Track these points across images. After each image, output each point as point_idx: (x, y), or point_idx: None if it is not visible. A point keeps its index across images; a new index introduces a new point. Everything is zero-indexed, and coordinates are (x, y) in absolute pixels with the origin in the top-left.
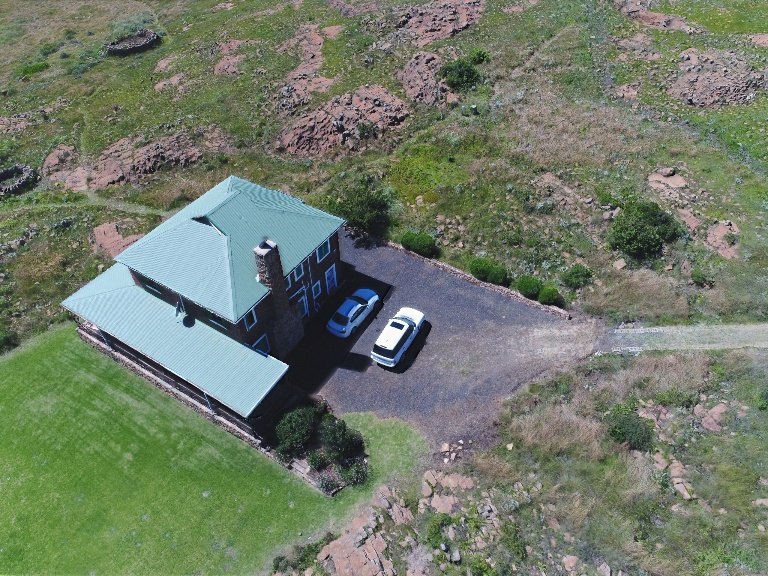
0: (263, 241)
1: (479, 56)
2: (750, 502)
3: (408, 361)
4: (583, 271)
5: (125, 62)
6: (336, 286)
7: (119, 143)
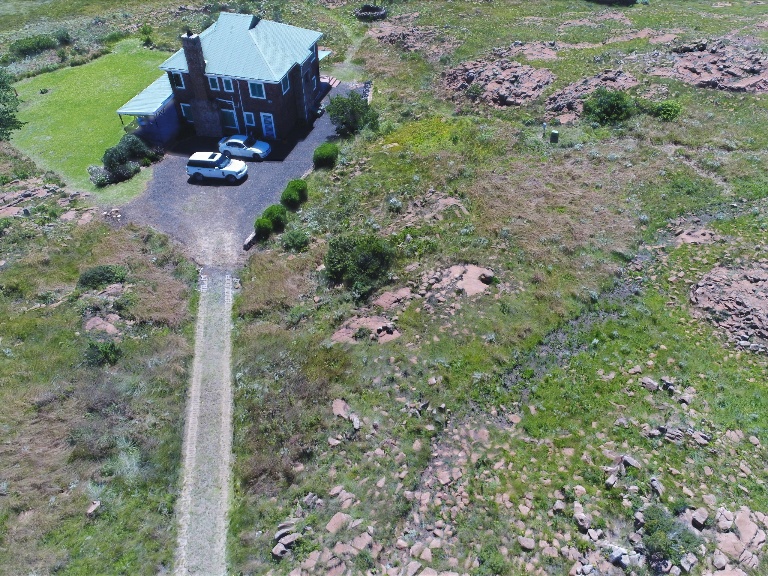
0: None
1: (661, 108)
2: (0, 333)
3: (199, 183)
4: (297, 239)
5: (576, 3)
6: (275, 137)
7: (429, 26)
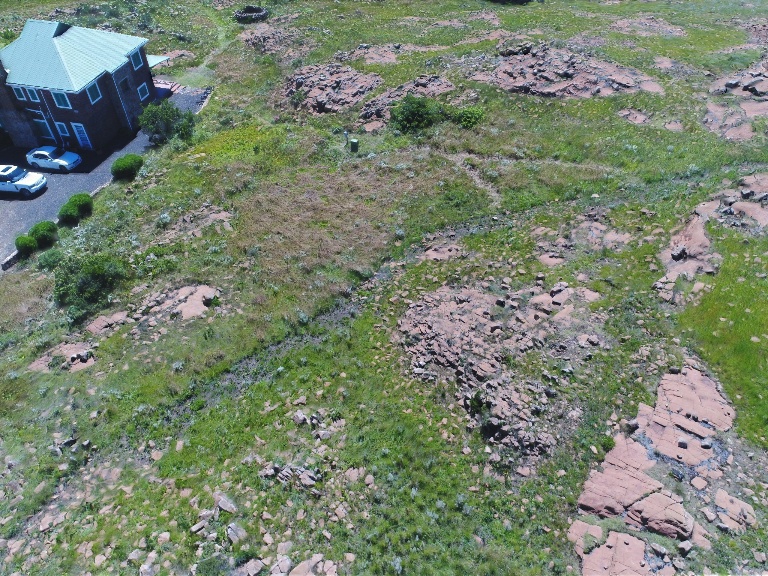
0: None
1: (462, 115)
2: None
3: None
4: (50, 259)
5: (470, 2)
6: (92, 147)
7: None
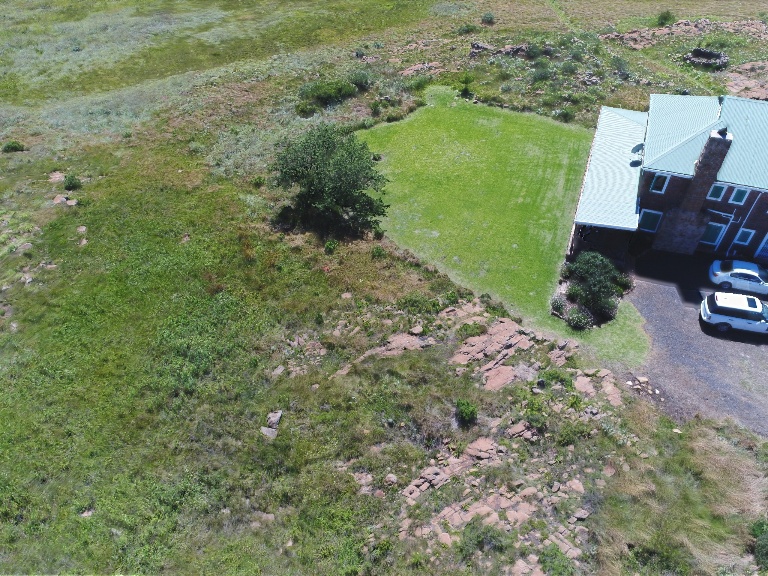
0: None
1: None
2: None
3: (723, 335)
4: None
5: None
6: None
7: None
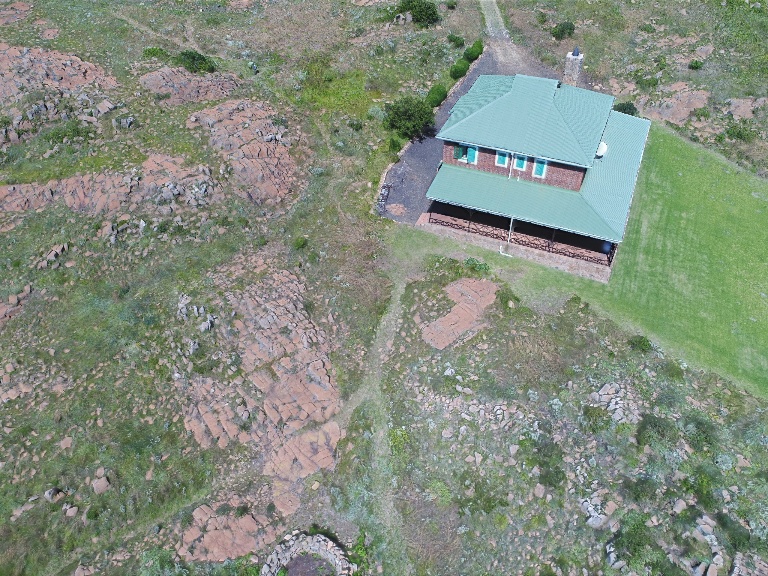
0: (576, 49)
1: None
2: None
3: None
4: None
5: None
6: None
7: (207, 420)
